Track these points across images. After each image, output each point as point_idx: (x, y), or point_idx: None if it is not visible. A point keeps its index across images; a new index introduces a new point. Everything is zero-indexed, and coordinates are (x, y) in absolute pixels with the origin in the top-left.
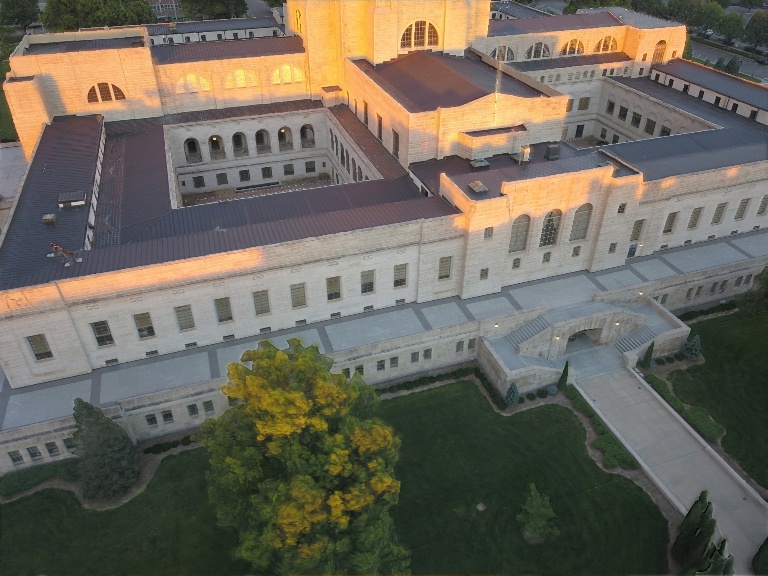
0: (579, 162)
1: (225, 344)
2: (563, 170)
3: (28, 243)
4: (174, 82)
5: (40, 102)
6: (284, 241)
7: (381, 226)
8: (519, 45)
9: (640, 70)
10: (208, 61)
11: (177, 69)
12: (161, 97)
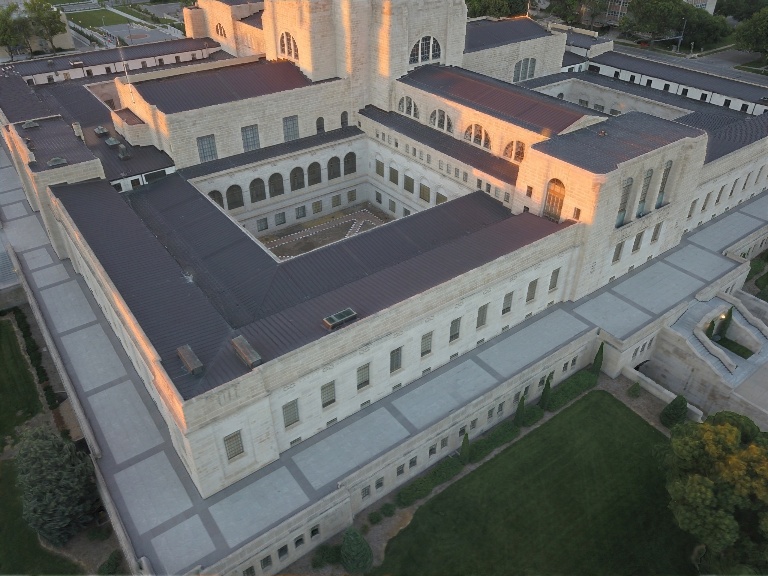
0: (81, 156)
1: (6, 147)
2: (62, 150)
3: (29, 66)
4: (243, 36)
5: (191, 24)
6: (3, 103)
7: (5, 117)
8: (422, 103)
9: (526, 209)
10: (253, 27)
11: (243, 27)
12: (236, 43)
